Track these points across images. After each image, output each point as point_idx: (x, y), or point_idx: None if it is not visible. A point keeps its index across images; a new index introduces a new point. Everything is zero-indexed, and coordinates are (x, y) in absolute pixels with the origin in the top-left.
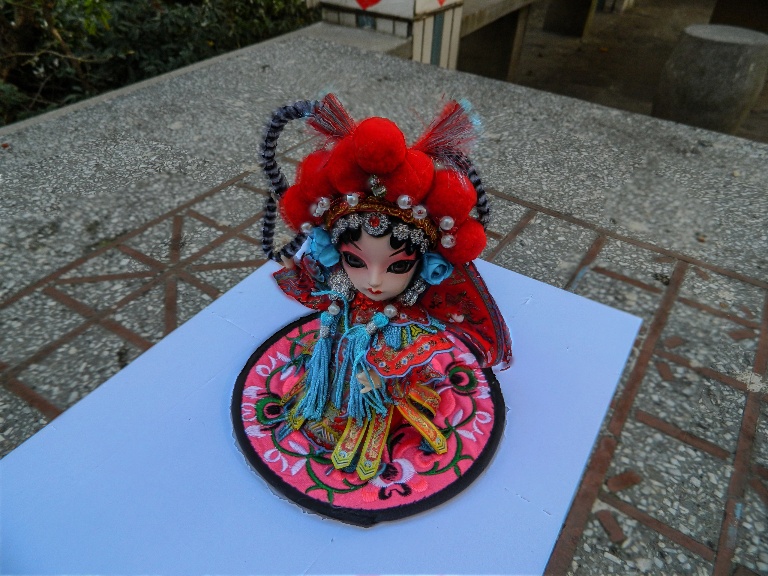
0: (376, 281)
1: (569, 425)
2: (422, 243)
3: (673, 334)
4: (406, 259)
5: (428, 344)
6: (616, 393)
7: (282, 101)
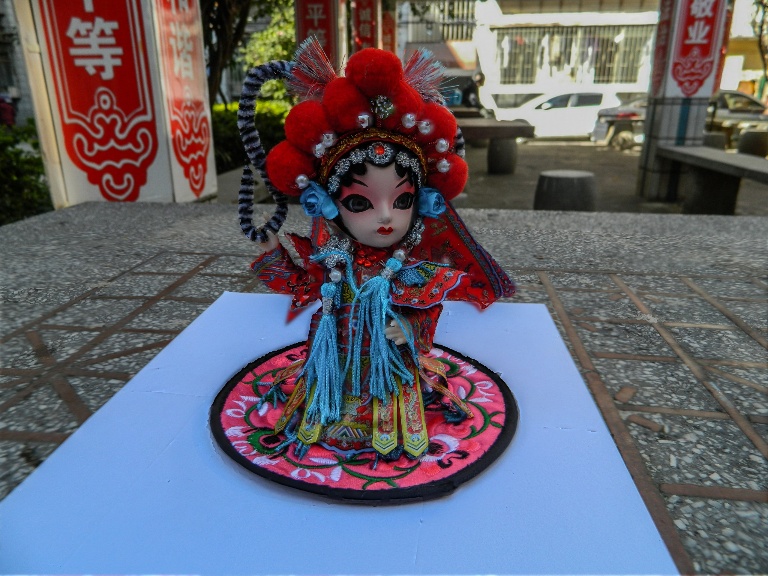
0: (388, 215)
1: (553, 374)
2: (418, 175)
3: (573, 307)
4: (408, 192)
5: (449, 272)
6: (568, 347)
7: (101, 240)
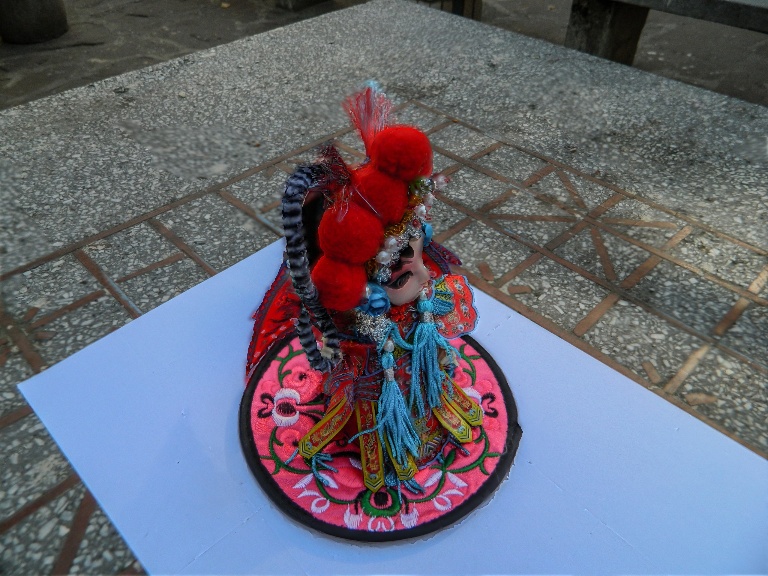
0: None
1: None
2: None
3: None
4: None
5: (457, 285)
6: None
7: None
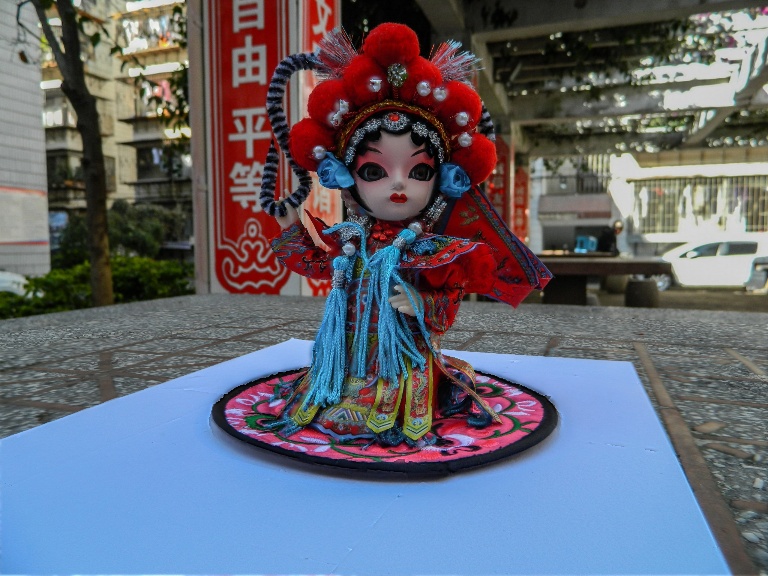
0: (401, 180)
1: (619, 407)
2: (439, 149)
3: (666, 365)
4: (426, 163)
5: (466, 242)
6: (647, 390)
7: (205, 310)
